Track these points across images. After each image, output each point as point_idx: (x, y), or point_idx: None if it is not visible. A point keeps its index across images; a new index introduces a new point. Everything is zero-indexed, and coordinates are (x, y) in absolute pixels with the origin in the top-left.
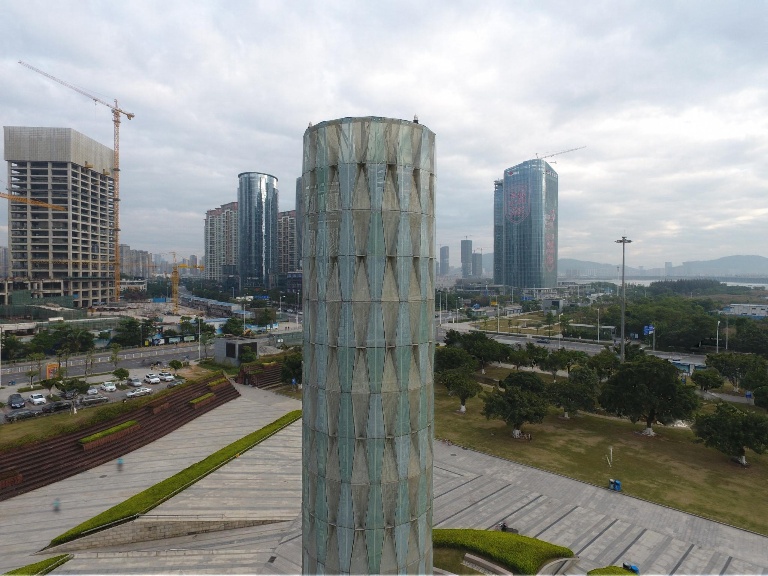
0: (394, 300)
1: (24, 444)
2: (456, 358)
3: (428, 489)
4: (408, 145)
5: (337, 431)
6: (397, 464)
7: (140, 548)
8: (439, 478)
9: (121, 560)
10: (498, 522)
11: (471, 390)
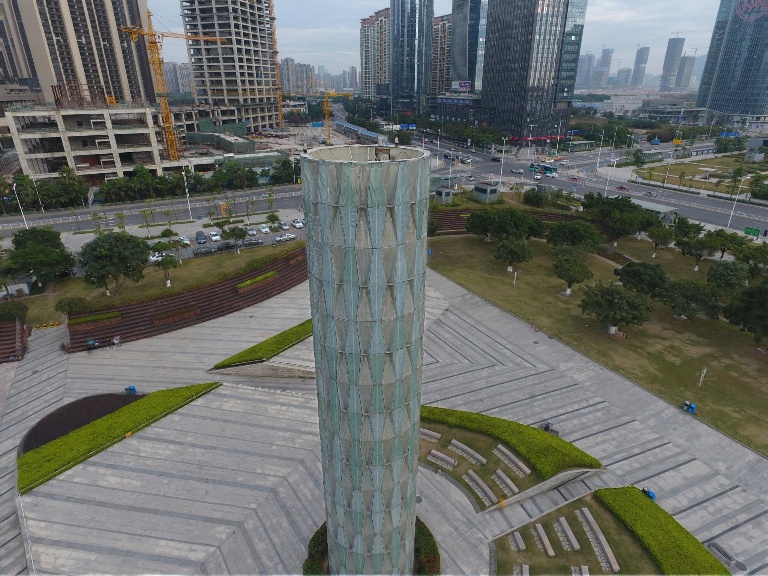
0: (368, 321)
1: (199, 286)
2: (579, 233)
3: (406, 443)
4: (381, 186)
5: (329, 401)
6: (373, 431)
7: (267, 382)
8: (511, 365)
9: (251, 392)
10: (546, 419)
11: (578, 277)
